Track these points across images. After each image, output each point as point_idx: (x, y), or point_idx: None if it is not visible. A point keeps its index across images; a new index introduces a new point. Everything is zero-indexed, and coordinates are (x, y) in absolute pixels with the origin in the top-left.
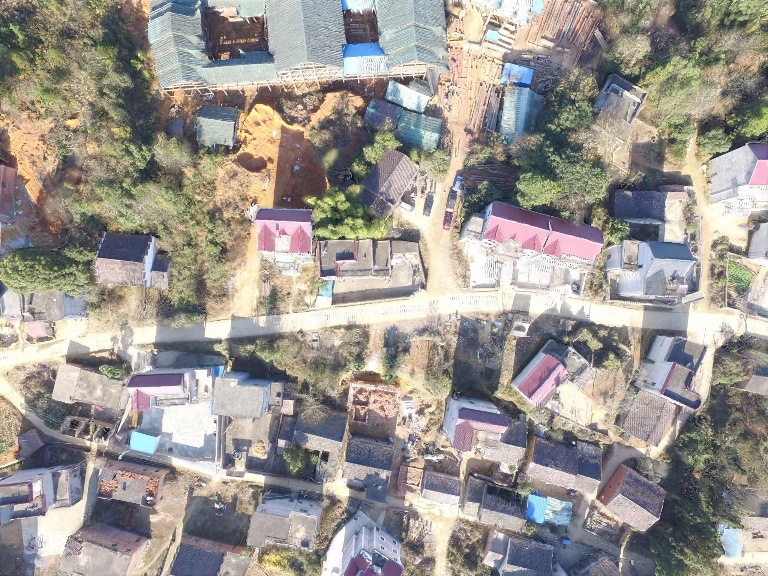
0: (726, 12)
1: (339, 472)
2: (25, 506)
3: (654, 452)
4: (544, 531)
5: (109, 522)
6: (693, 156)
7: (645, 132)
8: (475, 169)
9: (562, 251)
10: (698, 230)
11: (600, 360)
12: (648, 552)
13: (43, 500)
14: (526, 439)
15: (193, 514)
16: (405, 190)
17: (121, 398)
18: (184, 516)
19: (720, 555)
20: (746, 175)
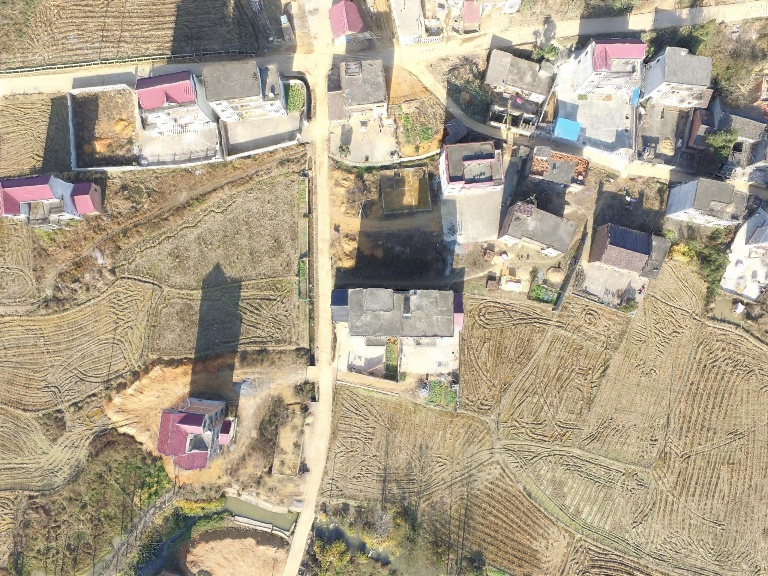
0: None
1: (739, 171)
2: (473, 174)
3: None
4: None
5: None
6: None
7: None
8: None
9: None
10: None
11: None
12: None
13: (491, 168)
14: None
15: (603, 208)
16: None
17: None
18: (595, 209)
19: None
20: None
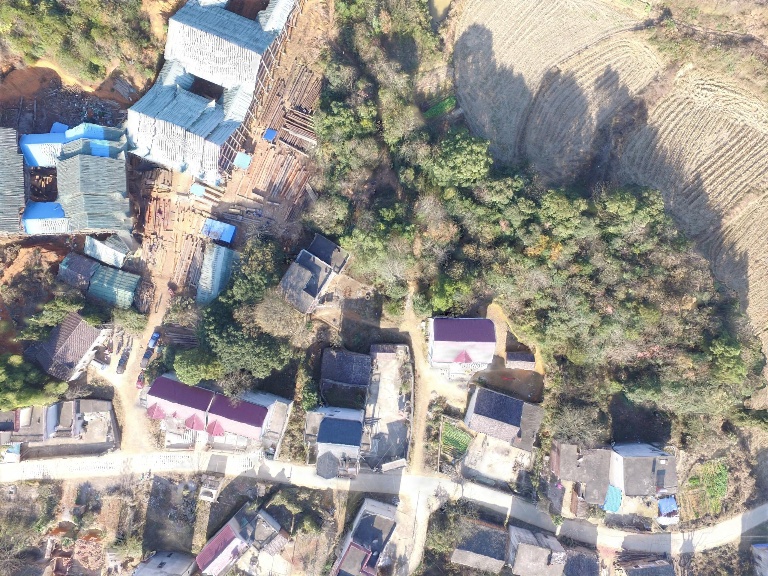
0: (432, 173)
1: None
2: None
3: None
4: None
5: None
6: (412, 313)
7: (359, 288)
8: (172, 327)
9: (225, 430)
10: (411, 391)
11: (296, 526)
12: None
13: None
14: None
15: None
16: (98, 347)
17: None
18: None
19: None
20: None
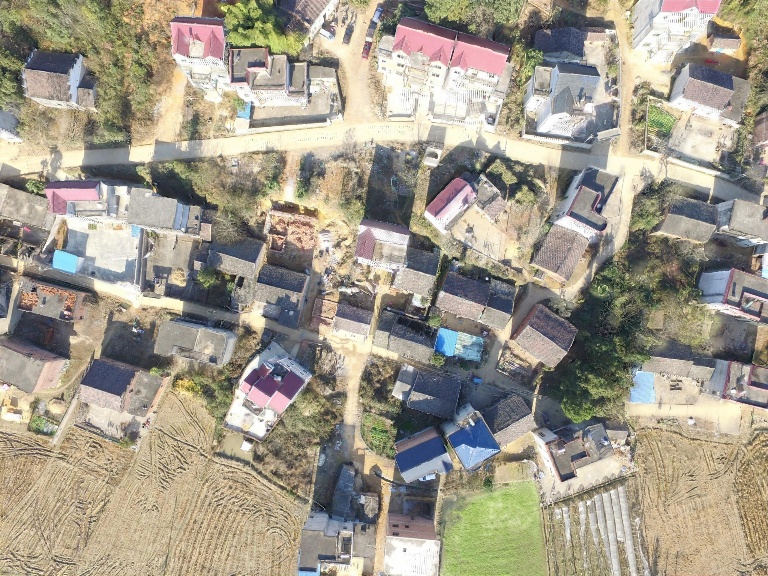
0: None
1: (256, 303)
2: None
3: (569, 293)
4: (457, 371)
5: (28, 337)
6: (617, 2)
7: None
8: (395, 1)
9: (468, 65)
10: (619, 73)
11: (513, 193)
12: (560, 393)
13: None
14: (437, 269)
15: (112, 338)
16: (325, 19)
17: (46, 217)
18: (103, 339)
19: (622, 379)
20: (659, 4)
